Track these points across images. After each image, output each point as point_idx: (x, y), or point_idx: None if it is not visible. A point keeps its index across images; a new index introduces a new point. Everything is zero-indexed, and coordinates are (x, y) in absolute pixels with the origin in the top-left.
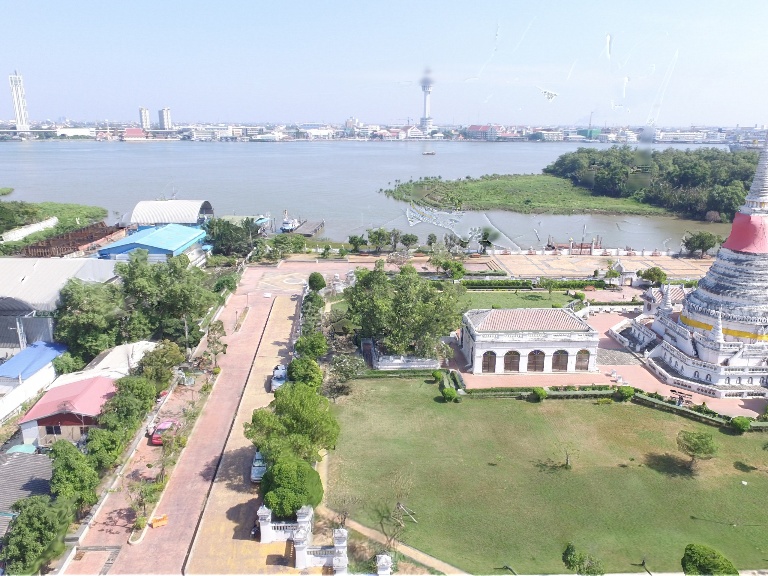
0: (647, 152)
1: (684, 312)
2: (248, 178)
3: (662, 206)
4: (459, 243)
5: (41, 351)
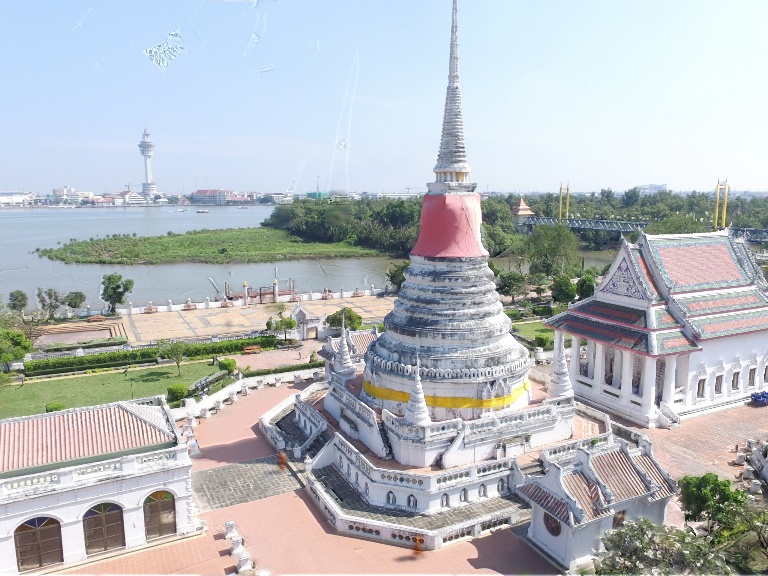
0: (343, 179)
1: (366, 374)
2: None
3: (375, 247)
4: (64, 302)
5: None
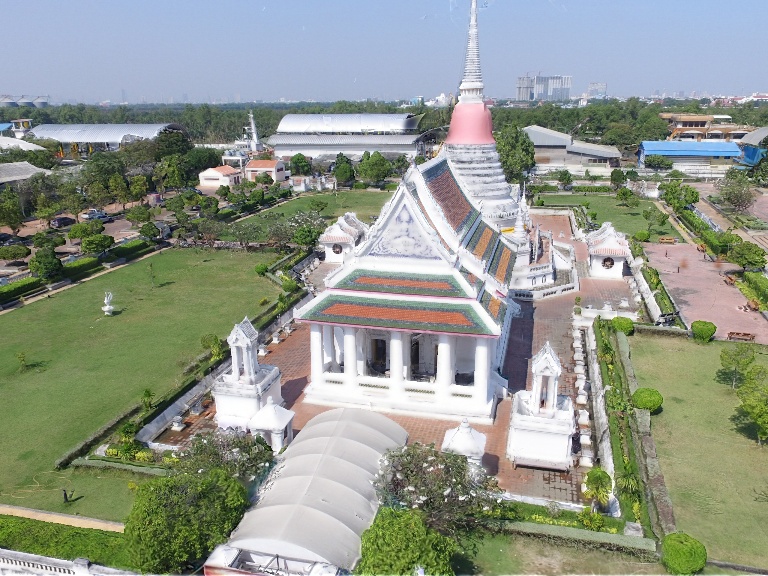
0: None
1: None
2: (432, 75)
3: None
4: None
5: None
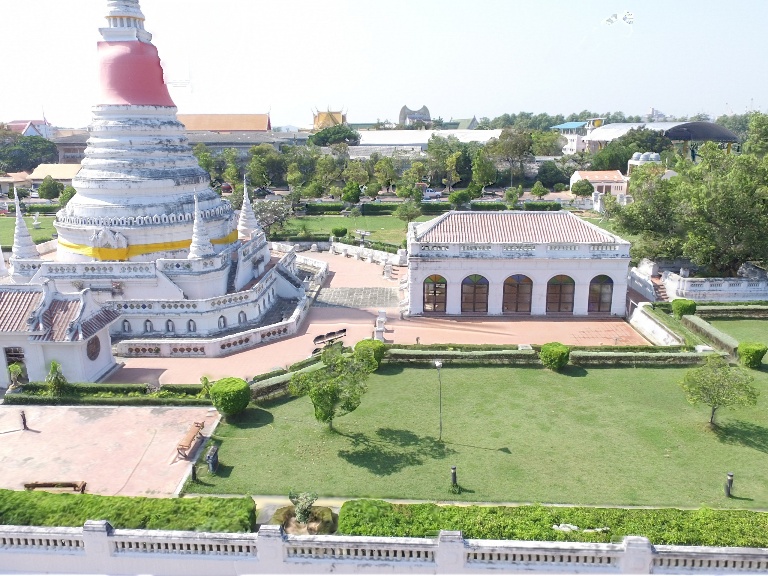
0: None
1: None
2: None
3: None
4: None
5: None
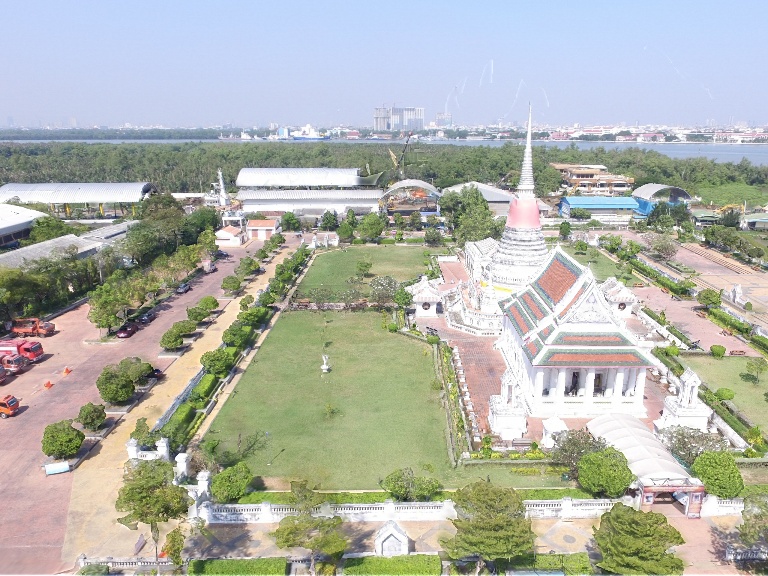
0: None
1: None
2: None
3: None
4: (747, 251)
5: (436, 212)
